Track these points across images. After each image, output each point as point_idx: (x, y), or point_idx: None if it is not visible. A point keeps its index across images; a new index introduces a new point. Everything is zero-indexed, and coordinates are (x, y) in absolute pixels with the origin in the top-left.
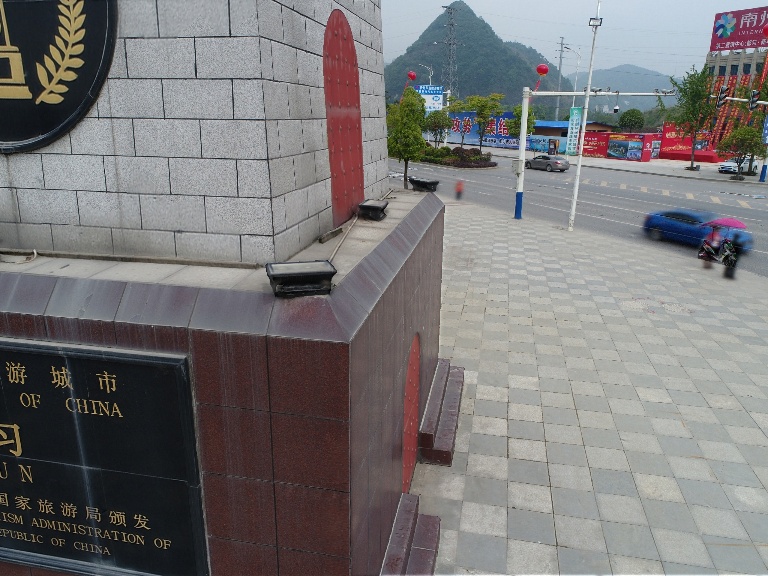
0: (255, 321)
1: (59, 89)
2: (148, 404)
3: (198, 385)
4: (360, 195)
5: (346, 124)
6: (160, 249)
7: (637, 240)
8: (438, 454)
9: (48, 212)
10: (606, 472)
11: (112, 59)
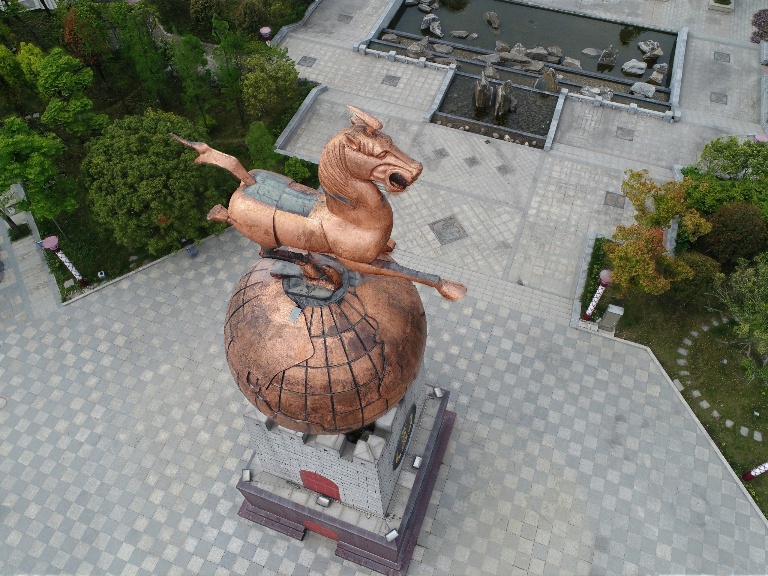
0: None
1: None
2: None
3: None
4: None
5: (322, 485)
6: None
7: None
8: None
9: None
10: None
11: None
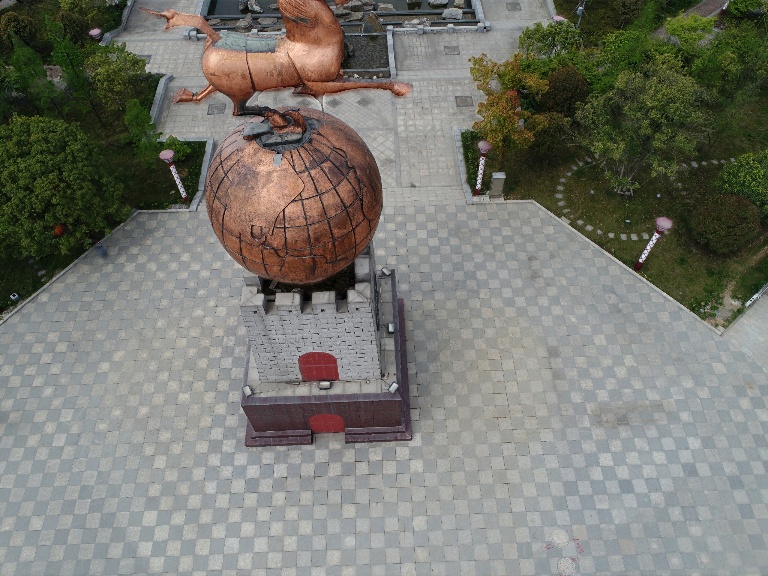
0: None
1: None
2: None
3: None
4: None
5: None
6: None
7: None
8: None
9: None
10: (353, 495)
11: None
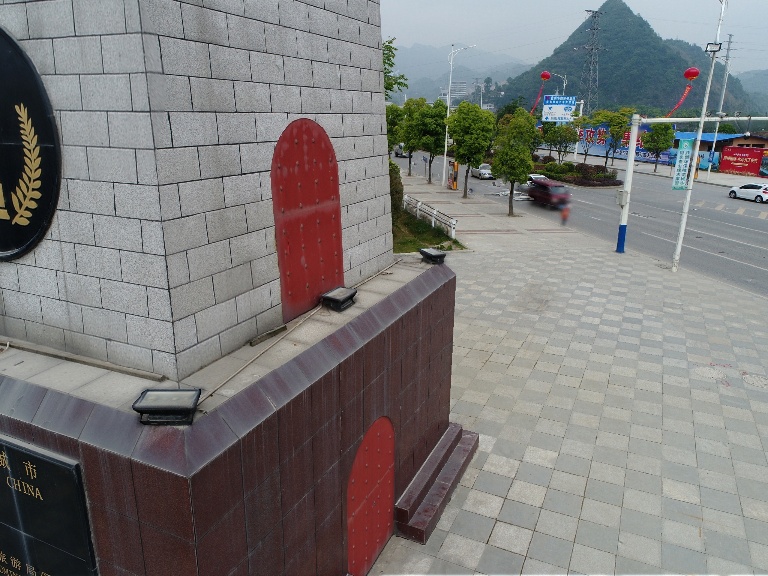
0: (126, 443)
1: (26, 214)
2: (58, 494)
3: (89, 487)
4: (337, 280)
5: (313, 220)
6: (97, 352)
7: (752, 287)
8: (413, 531)
9: (23, 310)
10: None
11: (59, 194)
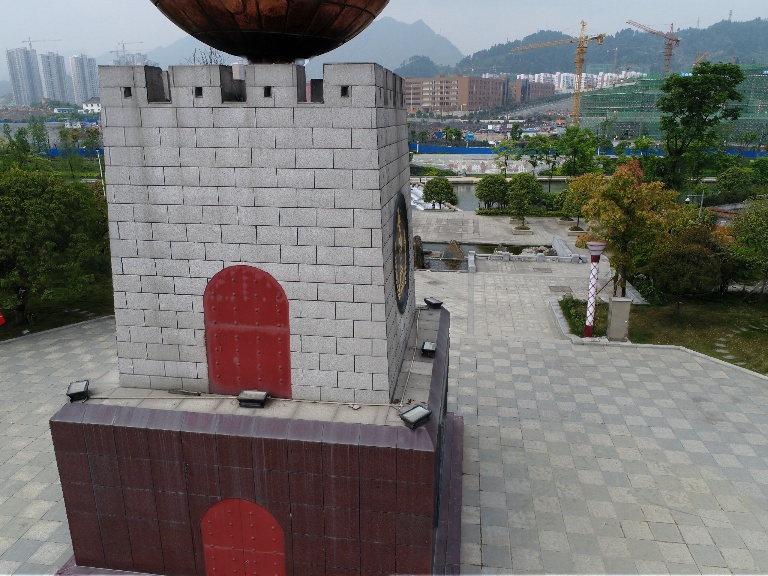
0: None
1: None
2: None
3: None
4: (281, 387)
5: (252, 336)
6: None
7: None
8: None
9: None
10: None
11: None
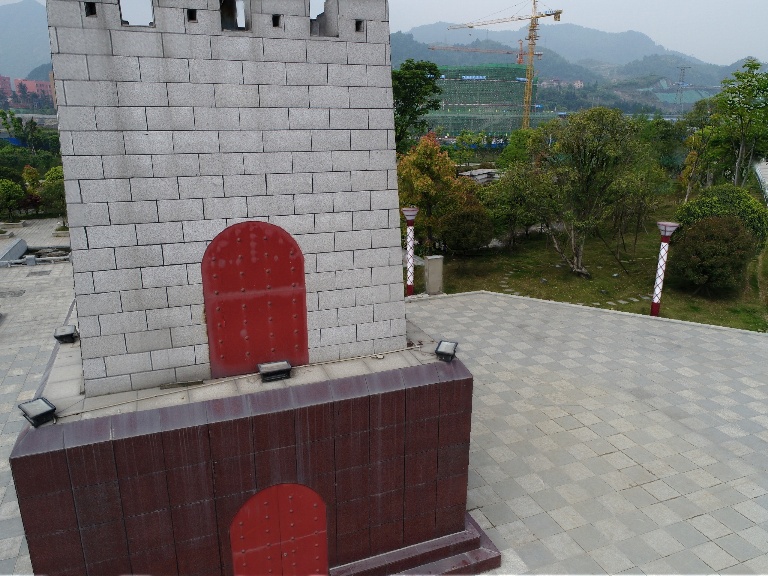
0: None
1: None
2: None
3: None
4: (297, 353)
5: (262, 302)
6: None
7: None
8: None
9: None
10: None
11: None
